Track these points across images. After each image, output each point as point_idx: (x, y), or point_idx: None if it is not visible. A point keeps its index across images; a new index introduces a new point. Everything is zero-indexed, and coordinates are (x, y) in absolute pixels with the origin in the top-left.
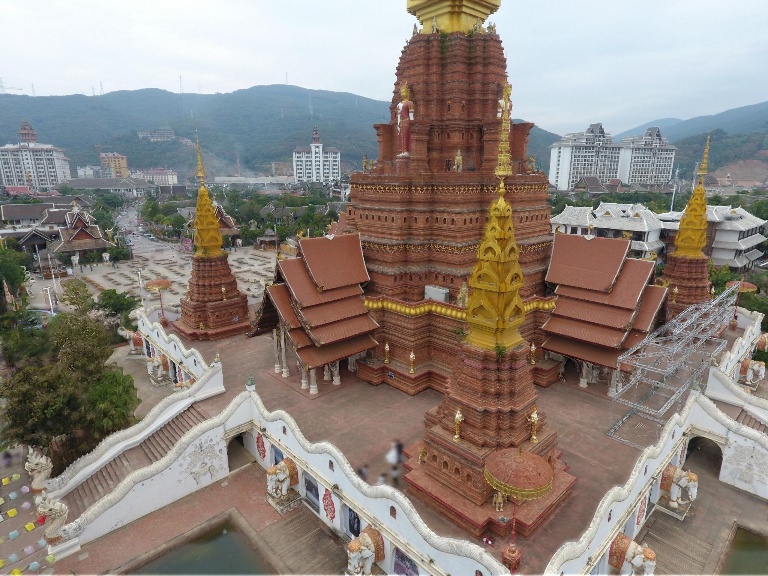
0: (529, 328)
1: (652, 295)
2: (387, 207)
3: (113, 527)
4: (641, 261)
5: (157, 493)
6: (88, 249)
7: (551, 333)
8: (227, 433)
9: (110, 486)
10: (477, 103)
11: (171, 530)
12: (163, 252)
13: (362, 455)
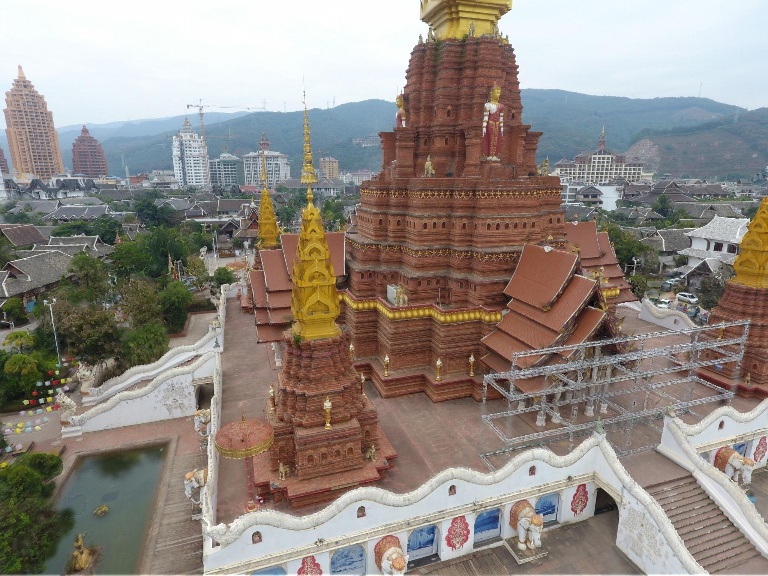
0: (470, 338)
1: (590, 319)
2: (371, 209)
3: (106, 427)
4: (585, 279)
5: (138, 412)
6: None
7: (486, 346)
8: (195, 381)
9: None
10: (462, 108)
11: (133, 439)
12: None
13: (256, 417)
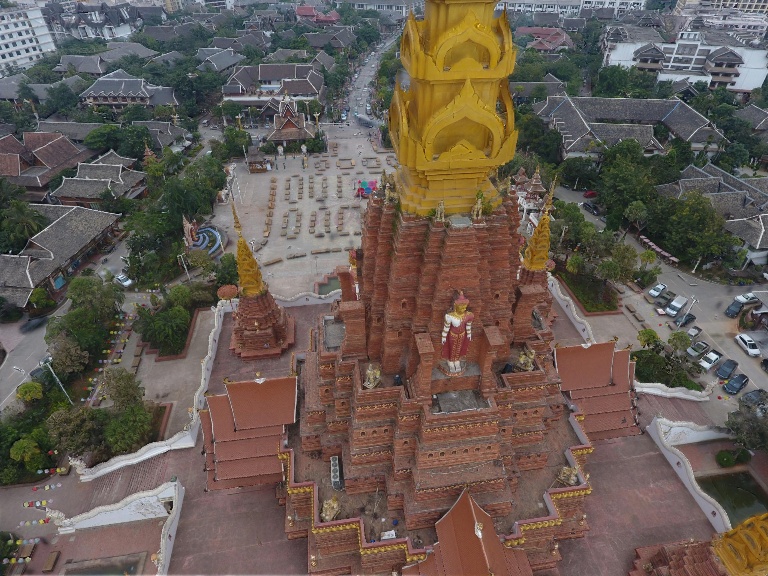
0: (394, 558)
1: None
2: None
3: (93, 525)
4: None
5: (117, 517)
6: (292, 139)
7: None
8: None
9: (106, 493)
10: (418, 308)
11: (112, 548)
12: (358, 141)
13: None
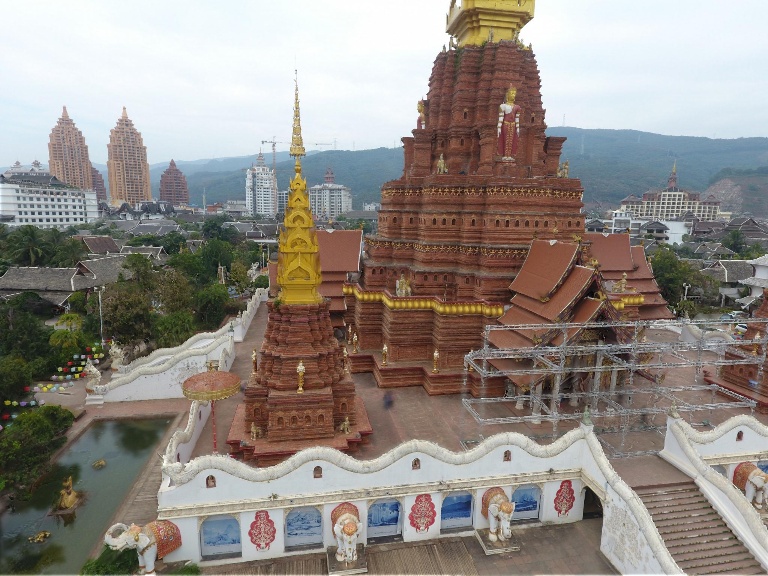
0: (470, 332)
1: (587, 309)
2: None
3: (125, 399)
4: (585, 269)
5: (155, 388)
6: None
7: None
8: None
9: None
10: (478, 109)
11: (145, 410)
12: None
13: None
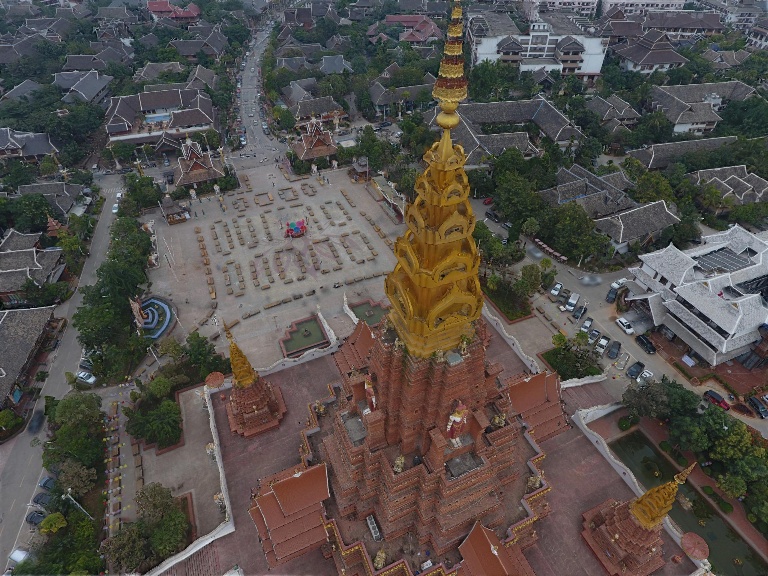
0: None
1: None
2: None
3: None
4: None
5: None
6: (202, 181)
7: None
8: None
9: None
10: (429, 413)
11: None
12: (267, 169)
13: None
